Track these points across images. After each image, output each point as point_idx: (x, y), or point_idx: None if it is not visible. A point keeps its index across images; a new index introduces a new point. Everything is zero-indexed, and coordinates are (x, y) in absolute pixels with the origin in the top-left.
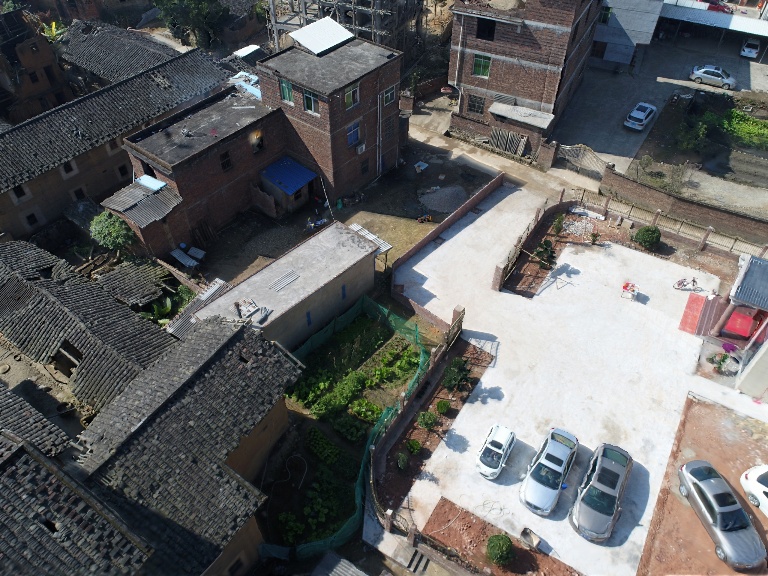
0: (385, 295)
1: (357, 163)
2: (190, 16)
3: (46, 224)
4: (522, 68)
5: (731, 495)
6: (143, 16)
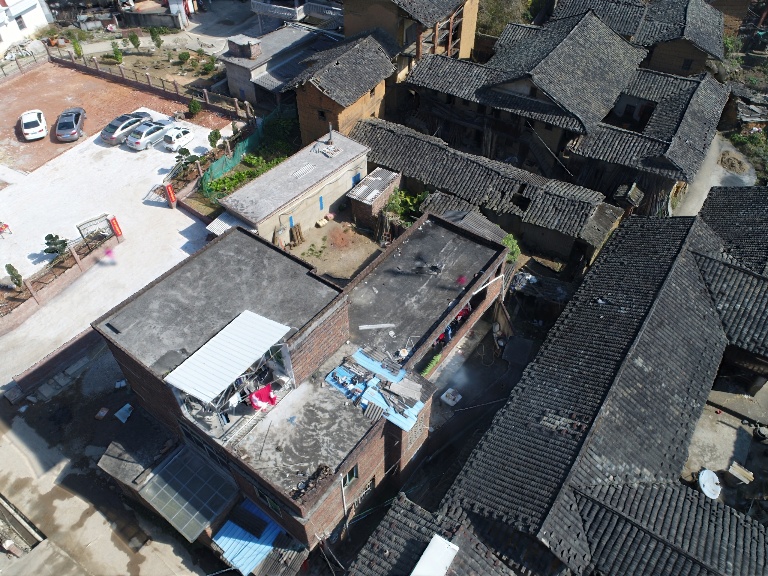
0: None
1: None
2: None
3: None
4: None
5: (62, 117)
6: None
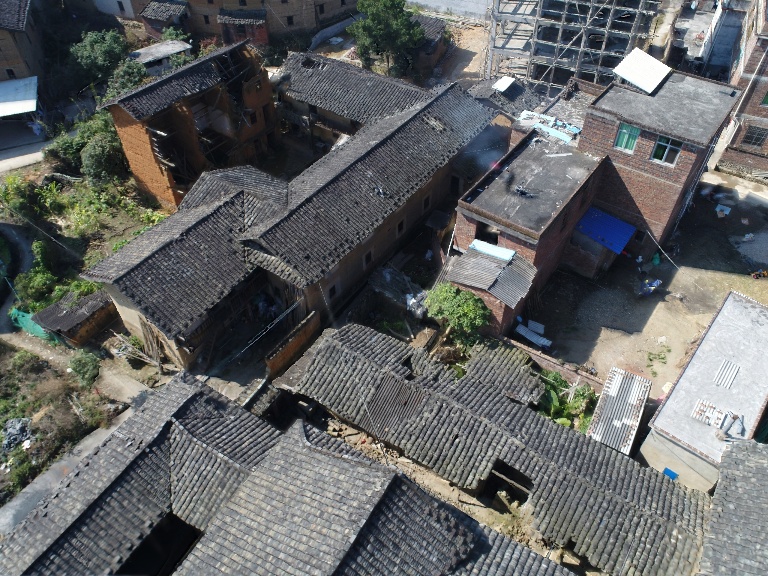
0: None
1: None
2: (398, 42)
3: (340, 295)
4: None
5: None
6: (313, 40)
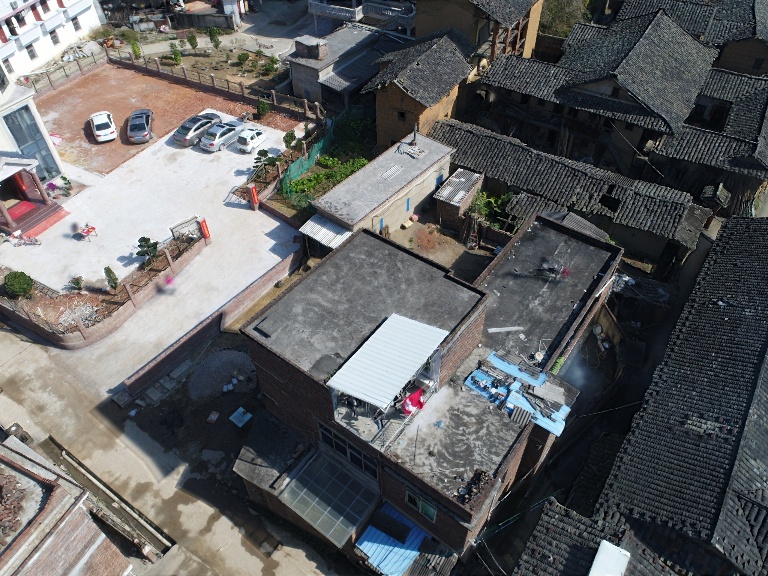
0: None
1: None
2: None
3: None
4: None
5: (132, 119)
6: None
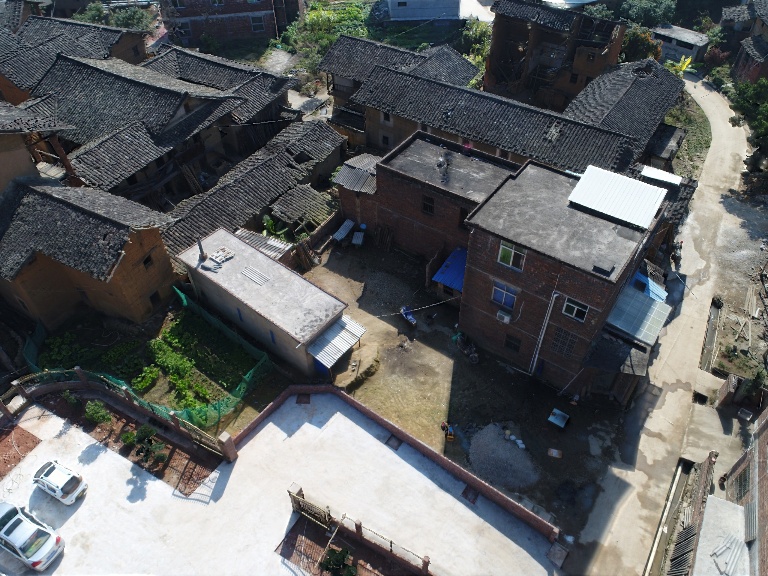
0: None
1: (500, 327)
2: None
3: None
4: None
5: None
6: None
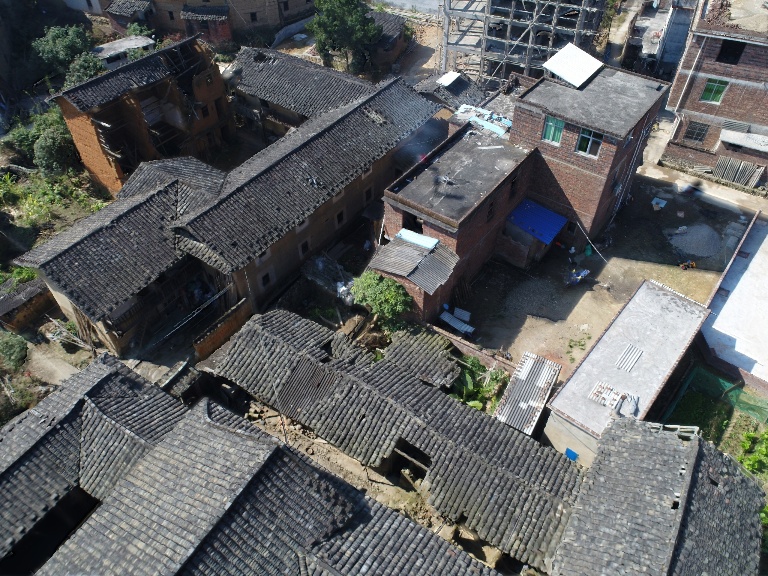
0: (698, 361)
1: (607, 204)
2: (353, 38)
3: (275, 283)
4: (767, 93)
5: None
6: (276, 36)
